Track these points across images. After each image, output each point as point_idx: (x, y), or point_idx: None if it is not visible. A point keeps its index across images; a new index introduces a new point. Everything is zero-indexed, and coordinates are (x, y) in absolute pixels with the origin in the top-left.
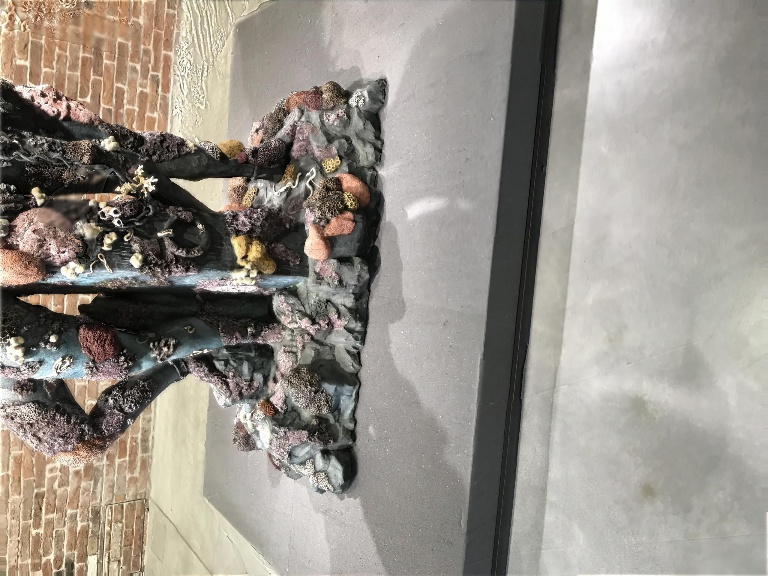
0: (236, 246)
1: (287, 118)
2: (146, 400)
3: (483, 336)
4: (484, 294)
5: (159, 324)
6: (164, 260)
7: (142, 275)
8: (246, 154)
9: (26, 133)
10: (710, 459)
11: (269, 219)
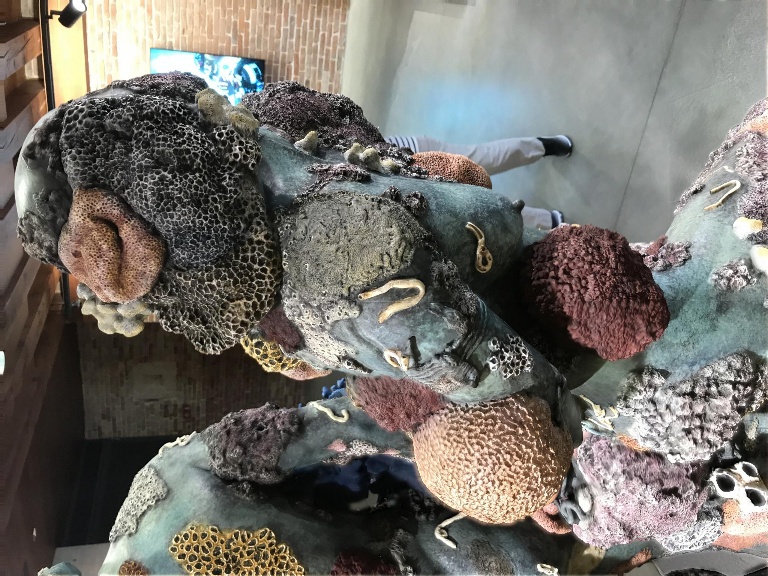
0: None
1: None
2: None
3: None
4: None
5: None
6: None
7: None
8: None
9: None
10: (680, 139)
11: None
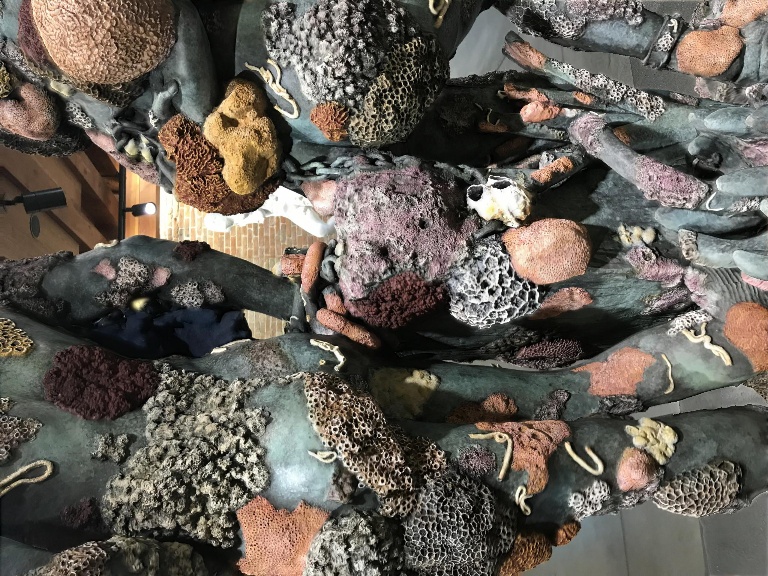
0: None
1: None
2: None
3: None
4: None
5: None
6: None
7: None
8: None
9: None
10: None
11: None
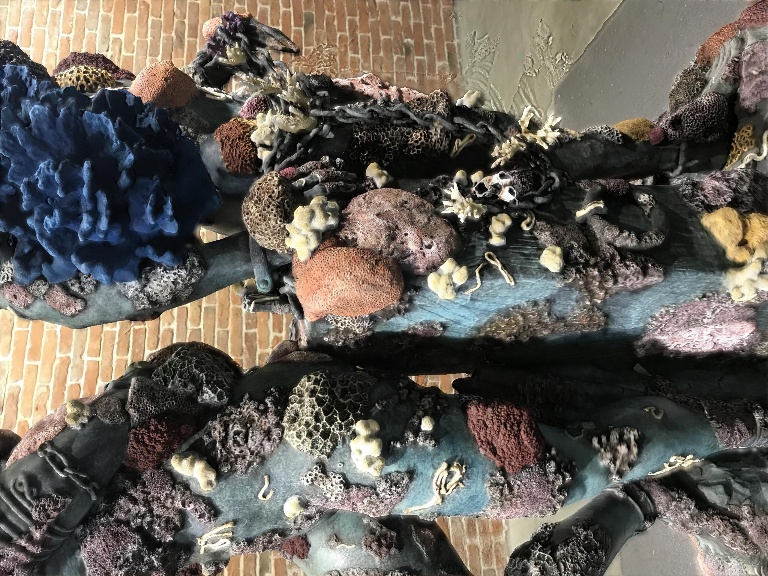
0: (720, 225)
1: (711, 69)
2: (598, 567)
3: None
4: None
5: (592, 411)
6: (599, 257)
7: (563, 292)
8: (662, 128)
9: (349, 105)
10: None
11: (760, 180)
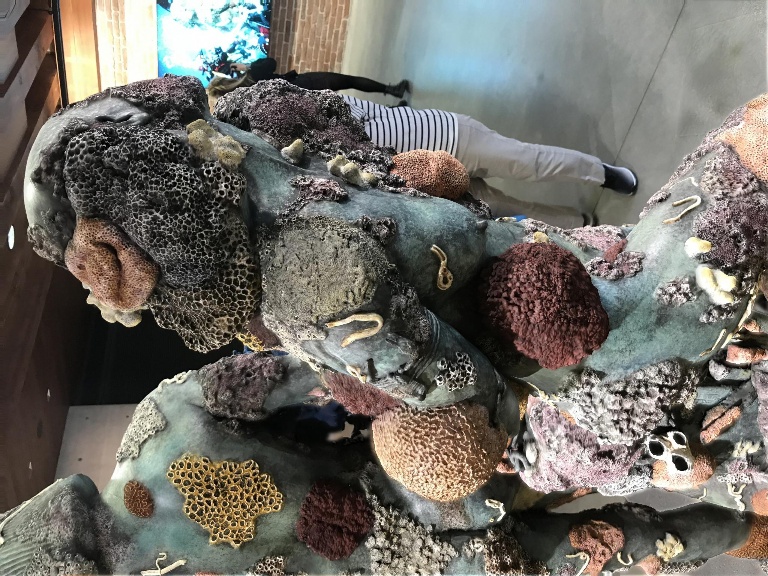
0: None
1: None
2: None
3: None
4: None
5: None
6: None
7: None
8: None
9: None
10: (696, 70)
11: None
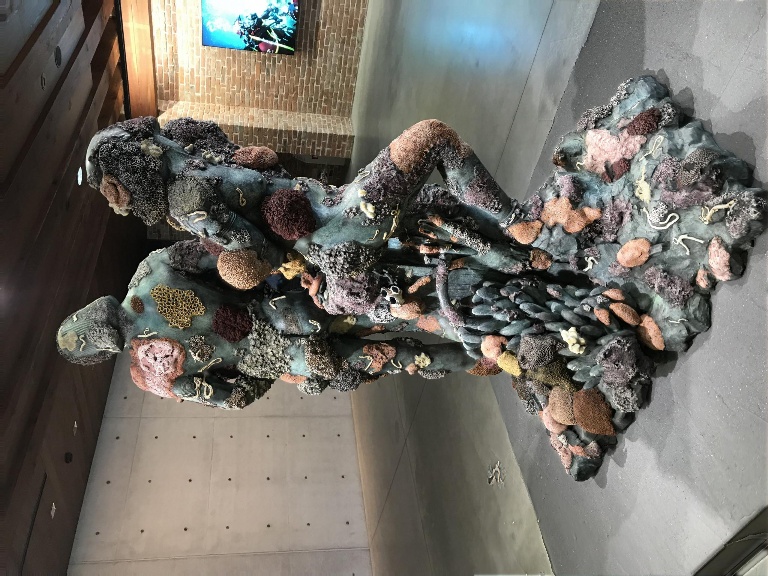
0: None
1: None
2: None
3: (541, 152)
4: (535, 173)
5: None
6: None
7: None
8: None
9: None
10: None
11: None
